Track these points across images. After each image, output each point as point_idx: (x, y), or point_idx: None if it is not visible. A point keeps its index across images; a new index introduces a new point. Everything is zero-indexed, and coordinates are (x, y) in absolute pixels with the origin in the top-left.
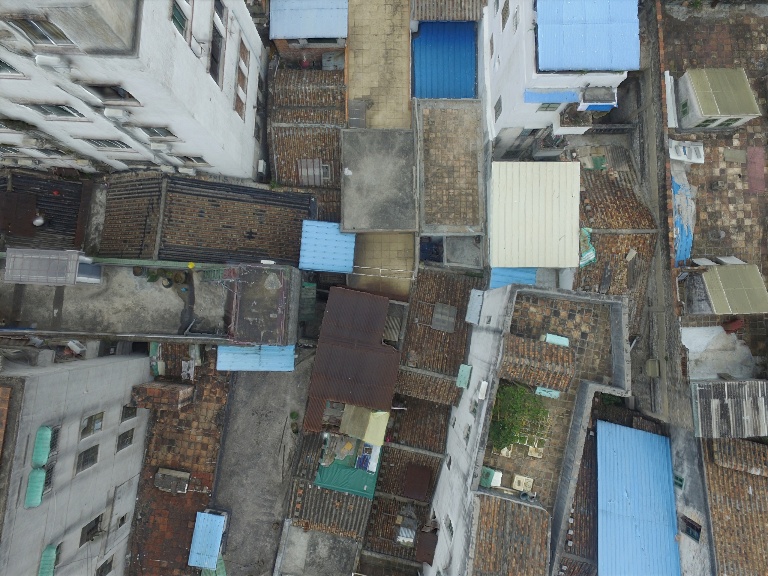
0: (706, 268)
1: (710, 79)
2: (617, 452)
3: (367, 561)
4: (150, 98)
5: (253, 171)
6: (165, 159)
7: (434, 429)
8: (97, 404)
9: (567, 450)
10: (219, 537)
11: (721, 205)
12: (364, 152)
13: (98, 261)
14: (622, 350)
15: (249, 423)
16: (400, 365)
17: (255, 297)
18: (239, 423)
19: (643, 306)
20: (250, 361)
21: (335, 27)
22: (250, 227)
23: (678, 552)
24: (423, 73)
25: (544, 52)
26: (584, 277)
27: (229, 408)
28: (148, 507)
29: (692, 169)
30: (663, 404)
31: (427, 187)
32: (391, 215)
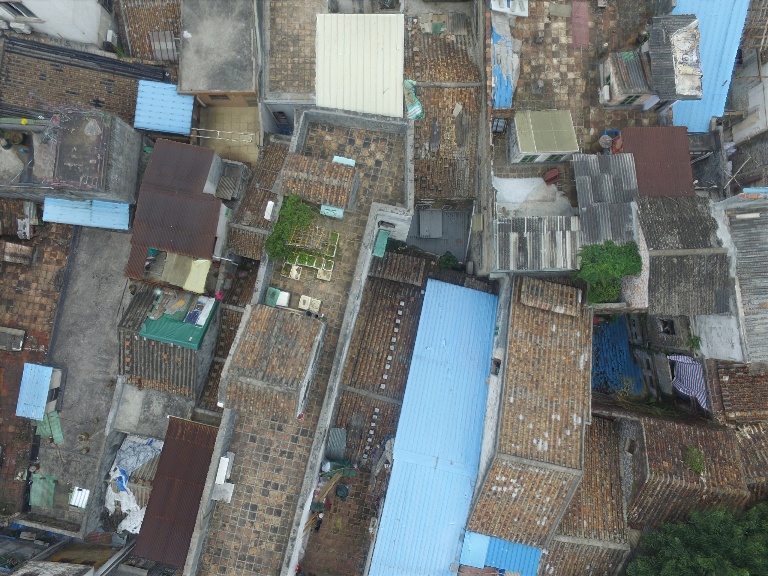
0: (514, 109)
1: None
2: (442, 306)
3: (200, 418)
4: None
5: (99, 39)
6: None
7: None
8: None
9: None
10: (46, 388)
11: (545, 59)
12: (204, 15)
13: None
14: (407, 171)
15: (89, 286)
16: (233, 223)
17: (75, 143)
18: (79, 285)
19: (475, 166)
20: (80, 215)
21: None
22: (97, 95)
23: (486, 393)
24: None
25: None
26: None
27: (69, 271)
28: None
29: (517, 23)
30: (485, 256)
31: (272, 55)
32: (229, 77)
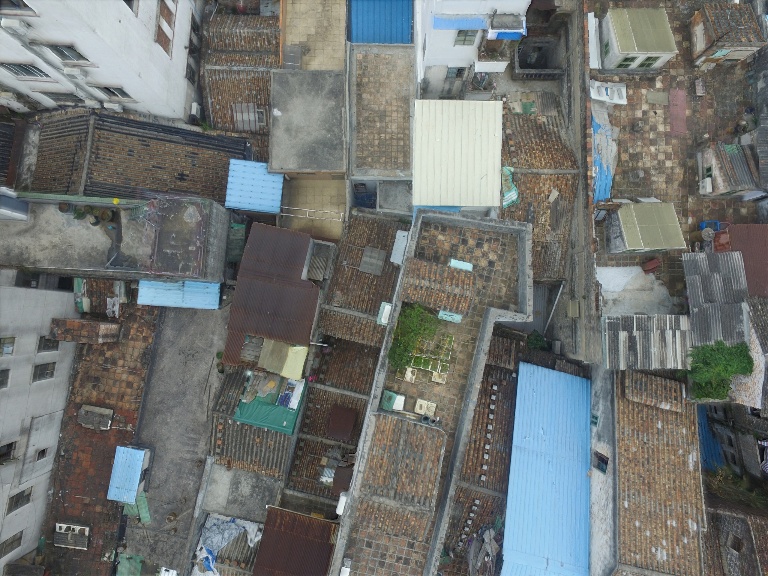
0: (620, 204)
1: (631, 18)
2: (537, 392)
3: (289, 500)
4: (42, 5)
5: (185, 113)
6: (88, 92)
7: (361, 372)
8: (6, 327)
9: (470, 376)
10: (138, 471)
11: (643, 147)
12: (294, 93)
13: (23, 196)
14: (525, 276)
15: (175, 363)
16: (324, 304)
17: (174, 229)
18: (165, 362)
19: (567, 249)
20: (173, 297)
21: None
22: (182, 169)
23: (589, 487)
24: (360, 20)
25: None
26: (508, 218)
27: (156, 347)
28: (71, 444)
29: (615, 110)
30: (581, 343)
31: (359, 131)
32: (319, 156)
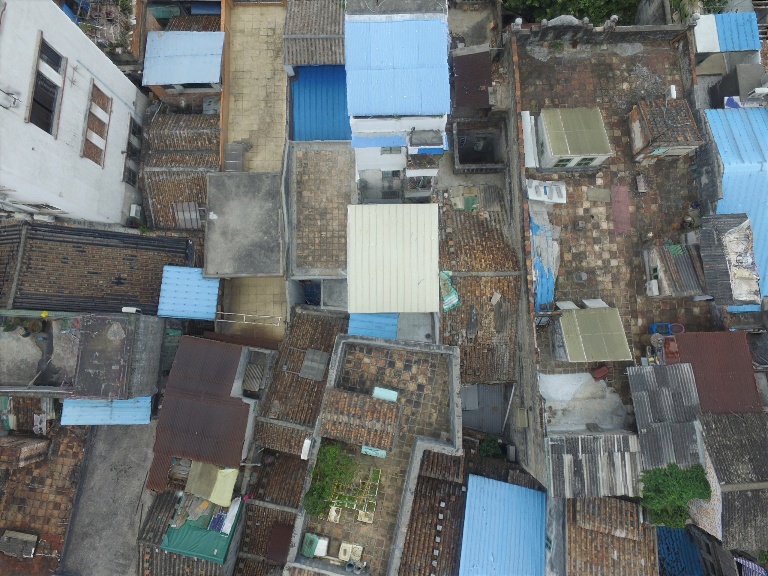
0: (560, 313)
1: (564, 119)
2: (487, 510)
3: None
4: None
5: (122, 216)
6: (15, 207)
7: None
8: None
9: (399, 514)
10: None
11: (586, 245)
12: (230, 196)
13: None
14: (453, 404)
15: (107, 480)
16: (260, 417)
17: (97, 348)
18: (96, 480)
19: (515, 351)
20: (100, 414)
21: (208, 73)
22: (119, 272)
23: None
24: (302, 115)
25: (353, 98)
26: (450, 322)
27: (86, 464)
28: None
29: (555, 209)
30: (531, 457)
31: (299, 229)
32: (256, 259)
